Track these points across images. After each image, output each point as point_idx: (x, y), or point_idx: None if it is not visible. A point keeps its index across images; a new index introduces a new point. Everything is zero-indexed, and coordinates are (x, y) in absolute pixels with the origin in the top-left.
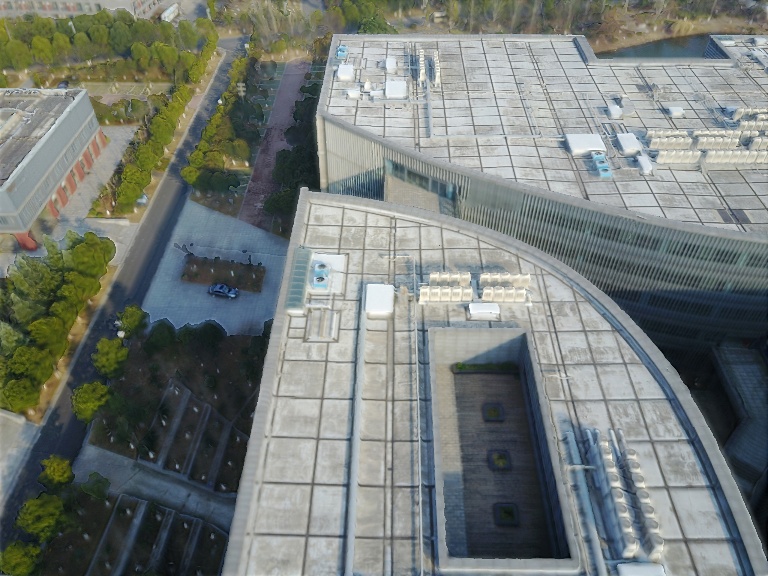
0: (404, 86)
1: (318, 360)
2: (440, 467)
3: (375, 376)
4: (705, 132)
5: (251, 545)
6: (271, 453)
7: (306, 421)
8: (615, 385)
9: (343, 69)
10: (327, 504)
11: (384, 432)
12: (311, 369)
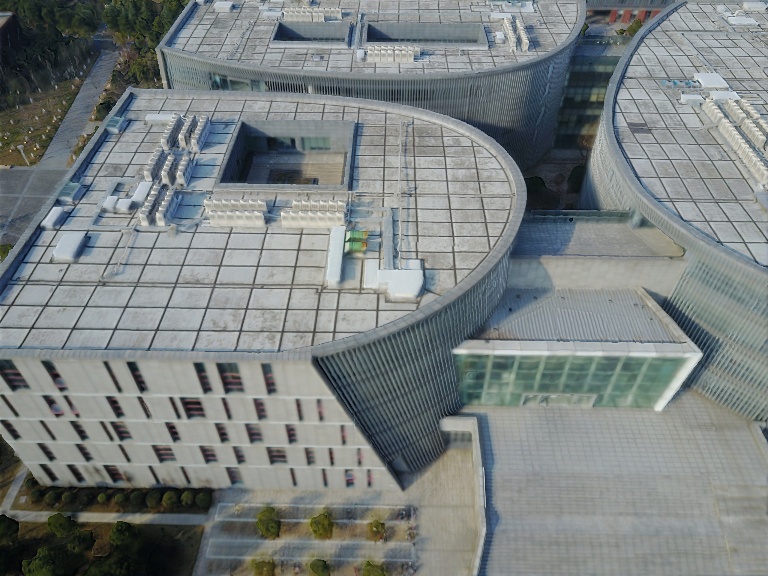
0: (748, 22)
1: (460, 8)
2: (405, 24)
3: (453, 18)
4: (763, 123)
5: (375, 1)
6: (411, 2)
7: (427, 7)
8: (457, 65)
9: (756, 3)
10: (391, 11)
11: (424, 20)
12: (454, 7)
